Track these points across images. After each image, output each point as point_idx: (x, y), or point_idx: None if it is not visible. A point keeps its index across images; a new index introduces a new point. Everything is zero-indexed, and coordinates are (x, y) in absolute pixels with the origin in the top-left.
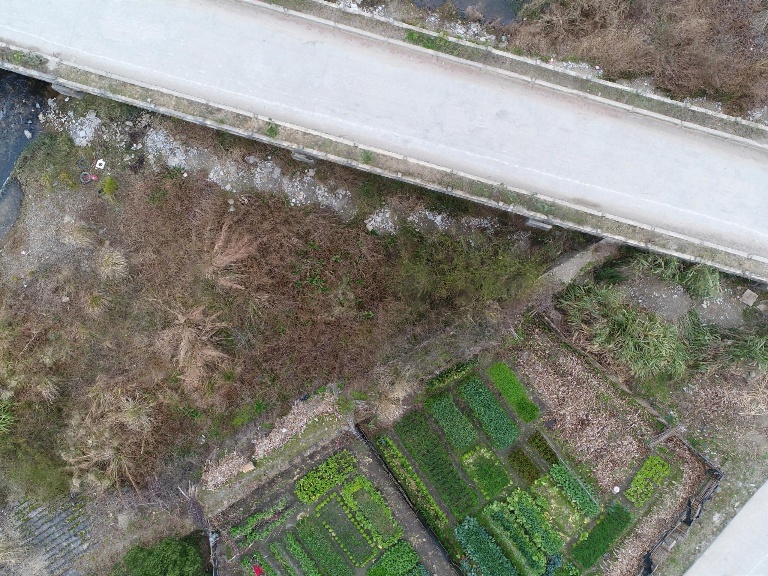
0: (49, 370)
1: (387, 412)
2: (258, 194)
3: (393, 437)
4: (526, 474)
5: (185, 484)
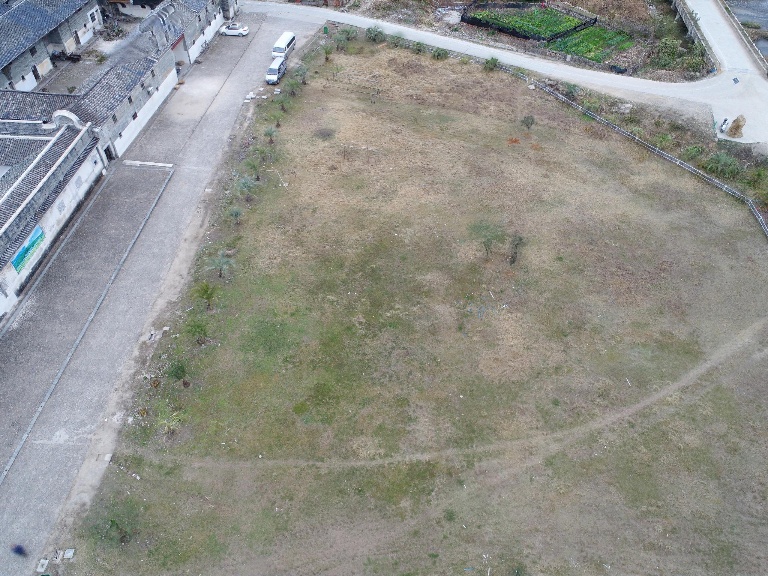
0: None
1: None
2: (652, 17)
3: None
4: (600, 47)
5: None
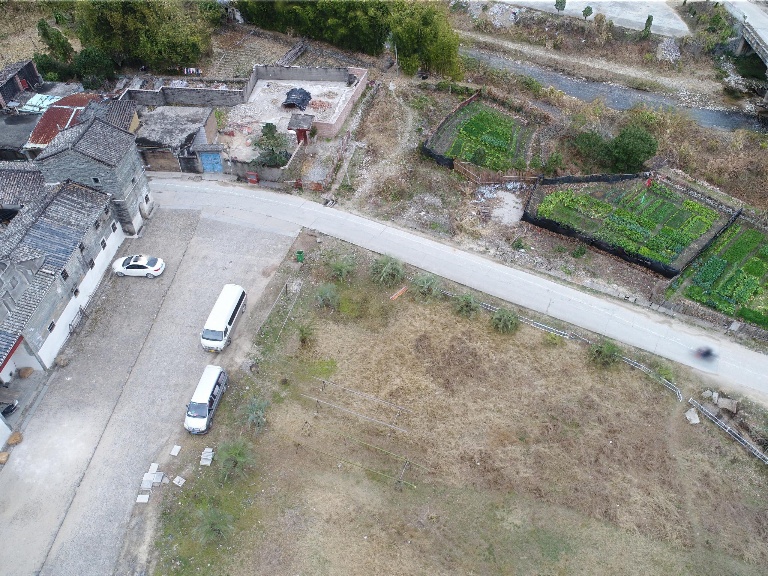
0: (674, 135)
1: (767, 209)
2: None
3: (741, 231)
4: None
5: (666, 164)
